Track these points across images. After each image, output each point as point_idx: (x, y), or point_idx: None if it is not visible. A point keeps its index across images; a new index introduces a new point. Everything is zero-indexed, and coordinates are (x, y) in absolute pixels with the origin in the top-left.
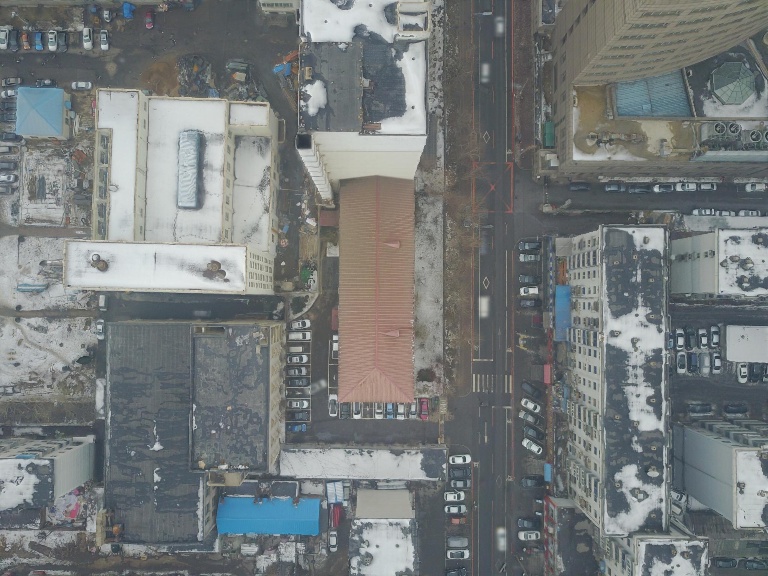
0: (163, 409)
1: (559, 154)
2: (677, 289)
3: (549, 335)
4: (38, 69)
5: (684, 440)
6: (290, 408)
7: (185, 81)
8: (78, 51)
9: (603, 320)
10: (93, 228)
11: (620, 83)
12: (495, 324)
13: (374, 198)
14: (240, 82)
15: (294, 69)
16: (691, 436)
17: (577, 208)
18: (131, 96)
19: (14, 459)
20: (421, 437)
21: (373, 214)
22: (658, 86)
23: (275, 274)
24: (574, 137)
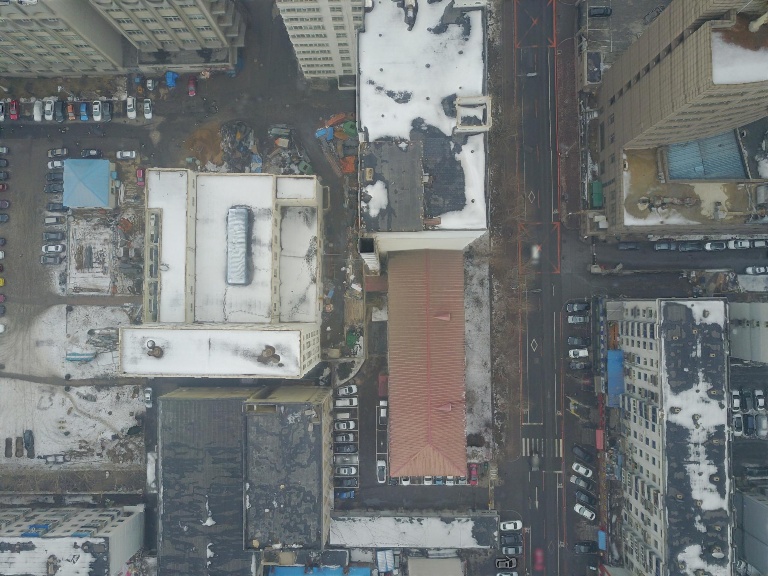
0: (215, 484)
1: (608, 216)
2: (734, 354)
3: (600, 399)
4: (83, 139)
5: (743, 507)
6: (338, 474)
7: (228, 148)
8: (122, 120)
9: (663, 396)
10: (145, 308)
11: (671, 145)
12: (544, 387)
13: (424, 271)
14: (283, 148)
15: (336, 133)
16: (751, 505)
17: (626, 268)
18: (180, 175)
19: (70, 537)
20: (471, 503)
21: (423, 288)
22: (710, 147)
23: (321, 340)
24: (625, 202)
